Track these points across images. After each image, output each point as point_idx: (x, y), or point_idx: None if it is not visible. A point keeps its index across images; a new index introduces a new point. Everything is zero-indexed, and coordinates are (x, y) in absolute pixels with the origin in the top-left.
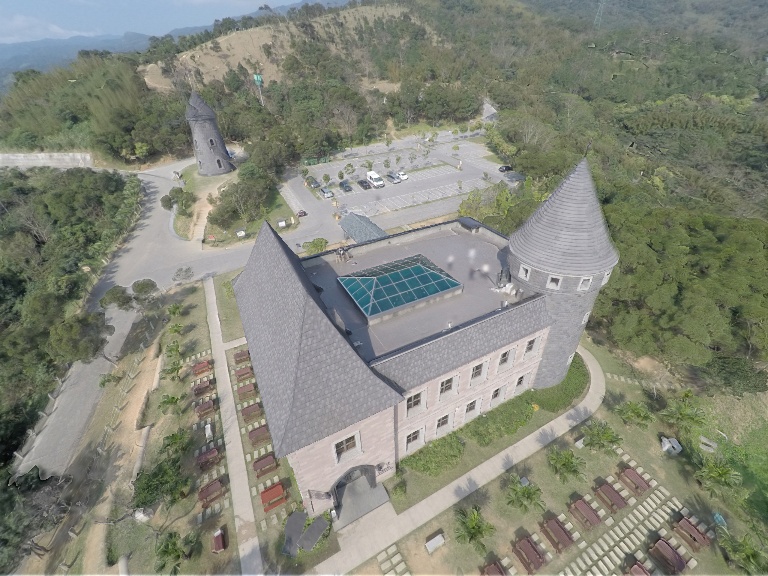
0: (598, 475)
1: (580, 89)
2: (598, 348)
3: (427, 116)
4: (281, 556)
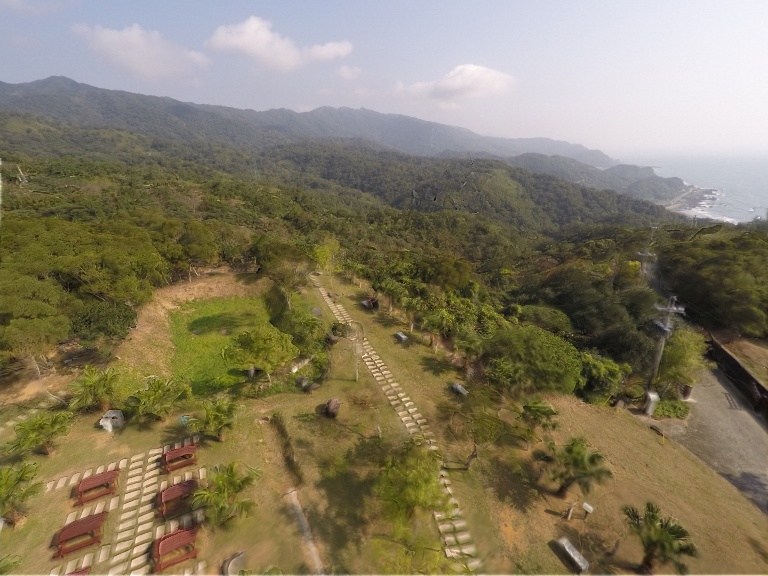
0: (52, 535)
1: None
2: None
3: None
4: None
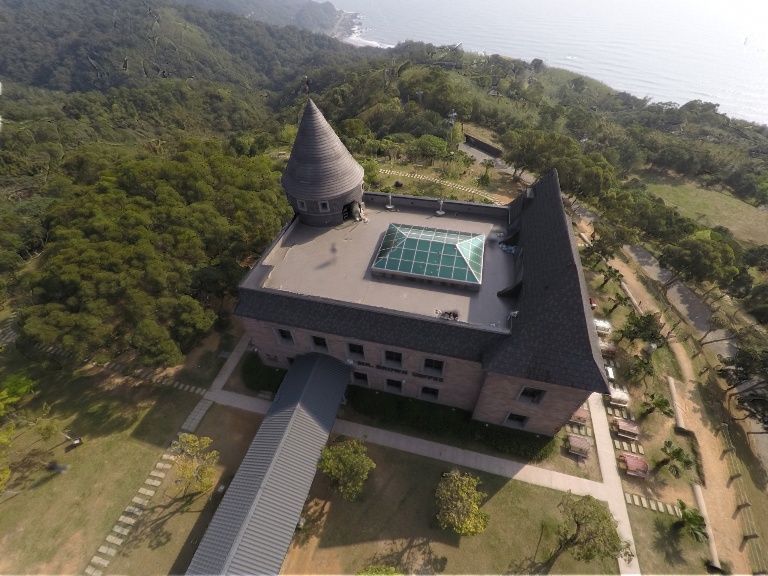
0: None
1: None
2: None
3: None
4: None
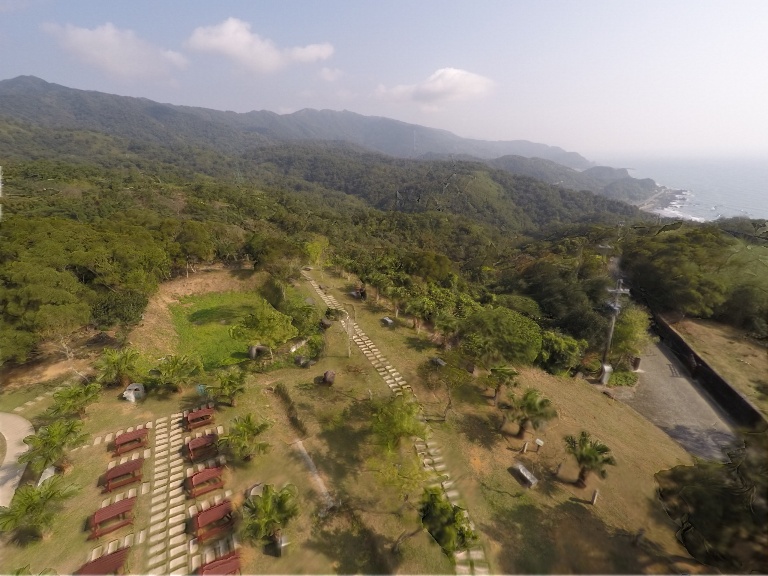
0: (97, 478)
1: None
2: None
3: None
4: None
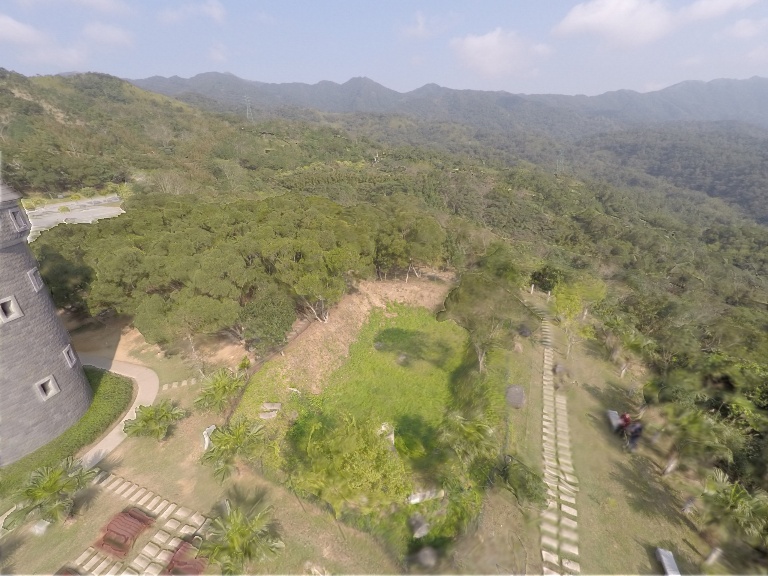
0: (63, 563)
1: (240, 161)
2: (167, 360)
3: (39, 188)
4: None
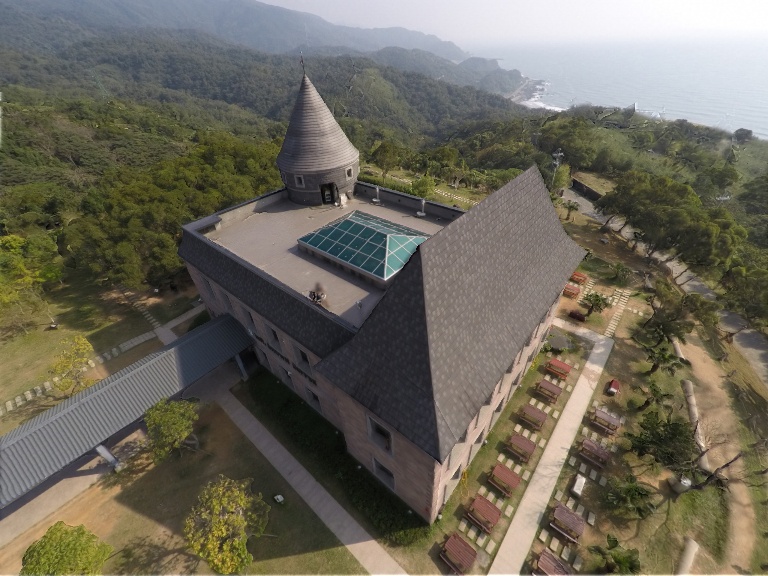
0: None
1: None
2: None
3: None
4: (577, 347)
